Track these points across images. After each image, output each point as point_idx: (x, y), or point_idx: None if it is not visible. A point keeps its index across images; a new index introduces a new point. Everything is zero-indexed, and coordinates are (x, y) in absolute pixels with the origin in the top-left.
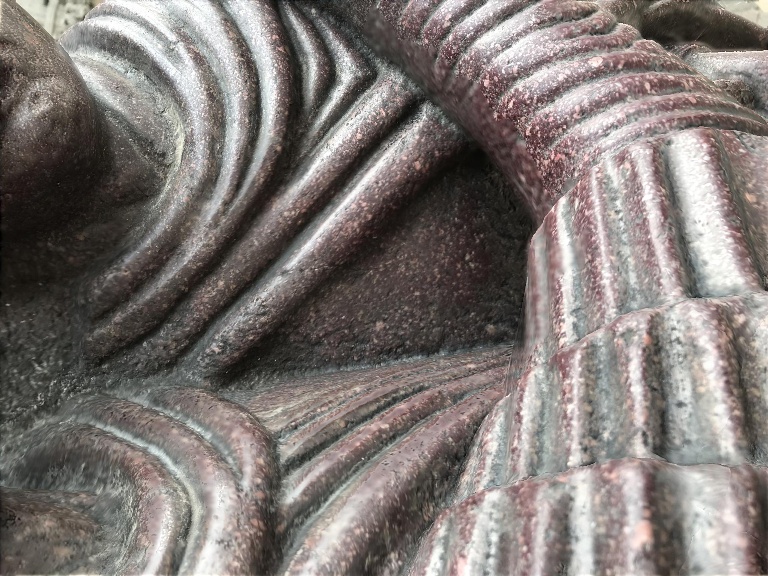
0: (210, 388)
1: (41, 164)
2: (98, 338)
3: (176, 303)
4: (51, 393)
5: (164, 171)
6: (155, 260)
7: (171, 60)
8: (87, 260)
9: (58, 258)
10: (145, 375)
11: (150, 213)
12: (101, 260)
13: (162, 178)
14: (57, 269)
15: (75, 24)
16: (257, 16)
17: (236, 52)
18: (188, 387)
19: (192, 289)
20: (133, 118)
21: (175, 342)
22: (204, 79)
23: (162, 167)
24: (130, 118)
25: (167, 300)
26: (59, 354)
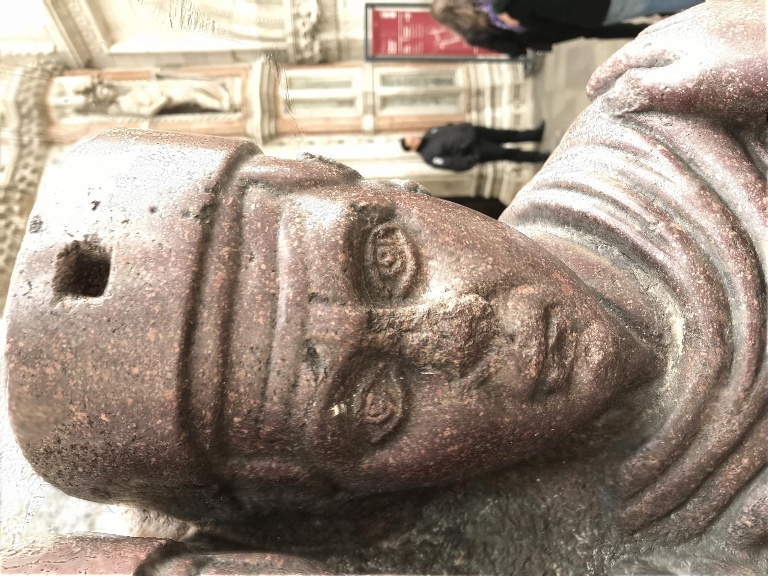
0: (750, 562)
1: (598, 405)
2: (631, 515)
3: (701, 482)
4: (596, 562)
5: (663, 351)
6: (679, 447)
7: (655, 243)
8: (605, 441)
9: (580, 443)
10: (677, 544)
11: (660, 396)
12: (618, 441)
13: (662, 358)
14: (579, 451)
15: (530, 200)
16: (739, 179)
17: (726, 227)
18: (734, 567)
19: (716, 468)
20: (624, 304)
21: (703, 515)
22: (697, 261)
23: (660, 347)
24: (621, 304)
25: (694, 481)
26: (592, 524)
